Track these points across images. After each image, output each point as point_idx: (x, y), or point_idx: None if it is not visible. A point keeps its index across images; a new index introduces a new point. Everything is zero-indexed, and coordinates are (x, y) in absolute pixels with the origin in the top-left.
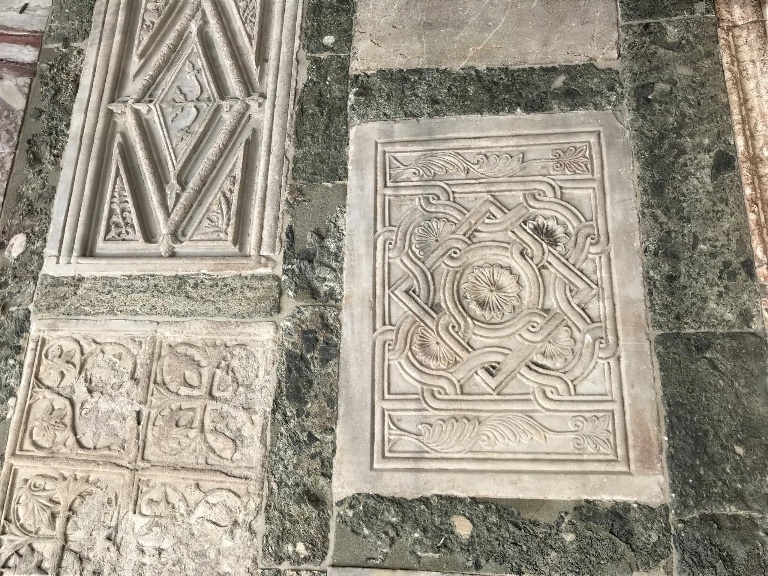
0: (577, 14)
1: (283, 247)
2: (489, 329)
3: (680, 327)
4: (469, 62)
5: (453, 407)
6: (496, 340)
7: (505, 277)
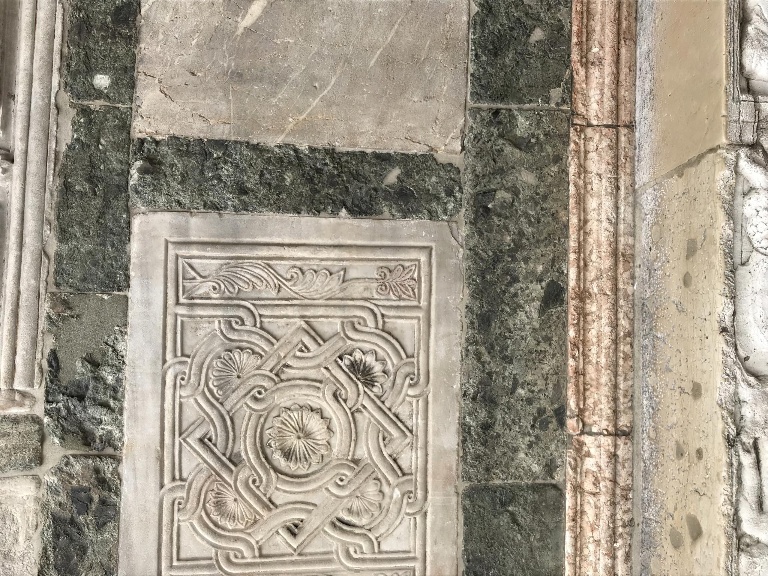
0: (421, 85)
1: (44, 379)
2: (294, 483)
3: (488, 478)
4: (287, 138)
5: (250, 571)
6: (301, 495)
7: (315, 421)
